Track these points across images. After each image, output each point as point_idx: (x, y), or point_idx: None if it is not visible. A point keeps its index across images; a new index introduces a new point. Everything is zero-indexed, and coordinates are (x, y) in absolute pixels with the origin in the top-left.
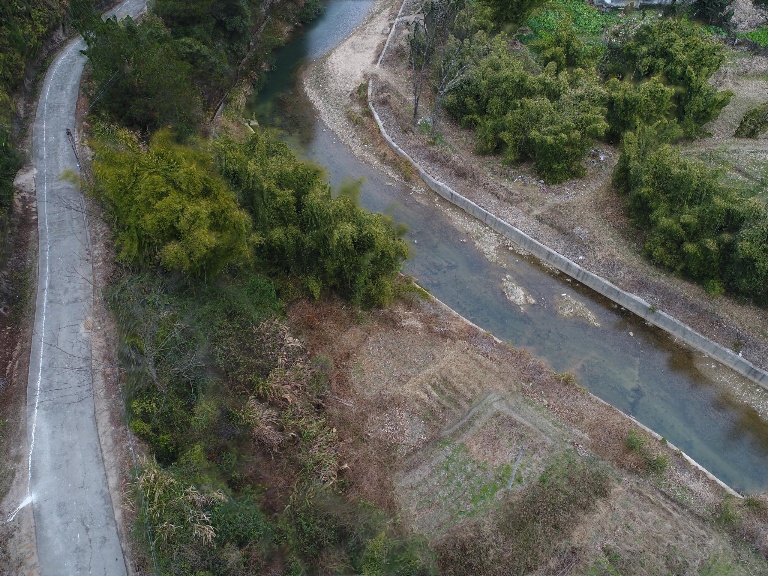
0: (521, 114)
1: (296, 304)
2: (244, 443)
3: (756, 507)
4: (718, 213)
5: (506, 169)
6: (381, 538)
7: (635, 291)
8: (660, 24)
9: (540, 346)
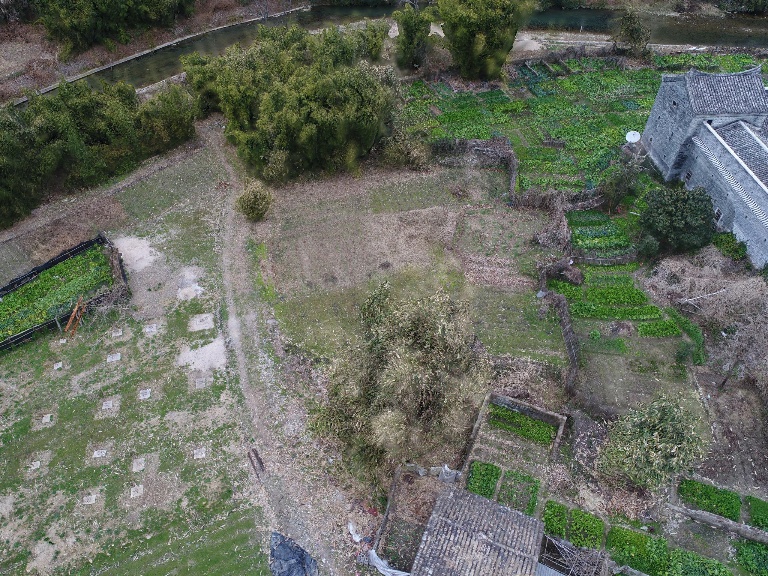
0: None
1: None
2: None
3: None
4: None
5: None
6: None
7: None
8: None
9: None
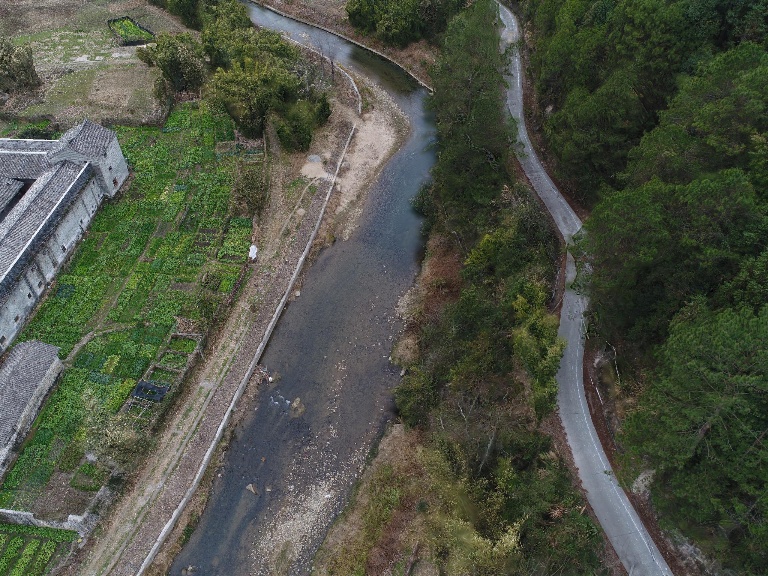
0: None
1: None
2: None
3: None
4: None
5: None
6: None
7: None
8: None
9: None
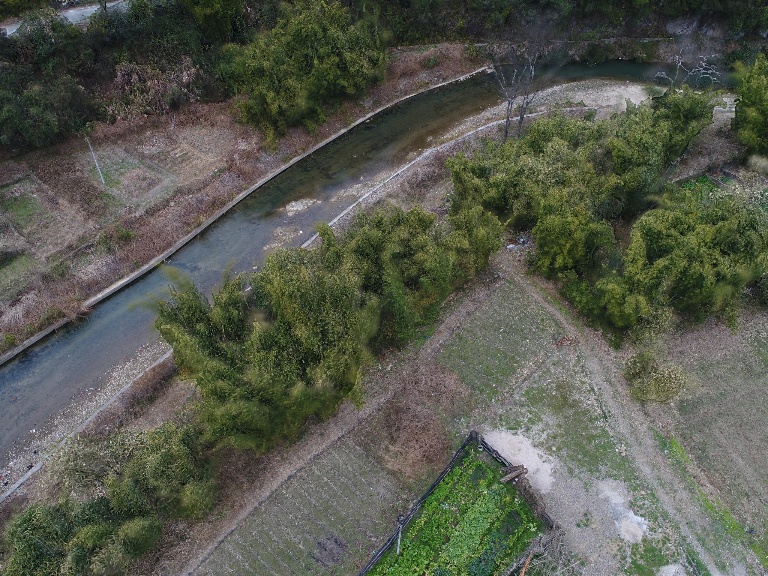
0: None
1: (246, 94)
2: (111, 65)
3: None
4: None
5: None
6: (36, 88)
7: None
8: None
9: (243, 219)
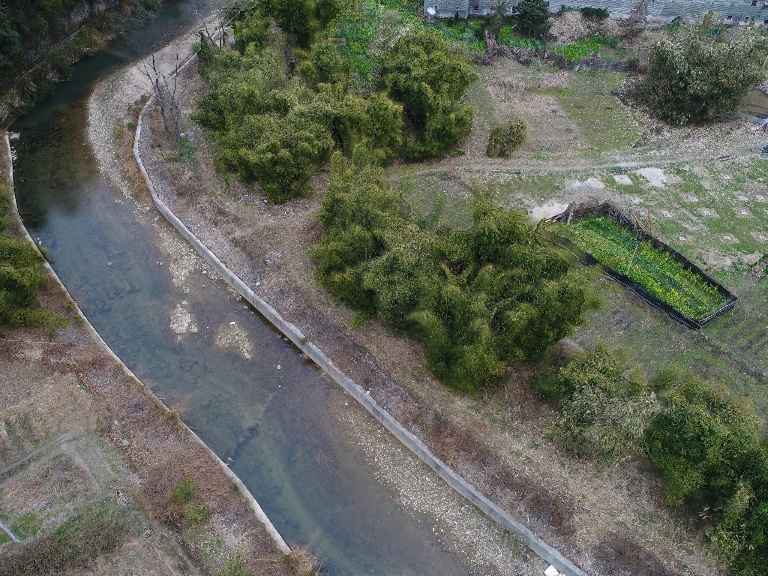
0: (245, 131)
1: None
2: None
3: (286, 565)
4: (364, 241)
5: (236, 187)
6: None
7: (295, 321)
8: (414, 38)
9: (177, 379)
